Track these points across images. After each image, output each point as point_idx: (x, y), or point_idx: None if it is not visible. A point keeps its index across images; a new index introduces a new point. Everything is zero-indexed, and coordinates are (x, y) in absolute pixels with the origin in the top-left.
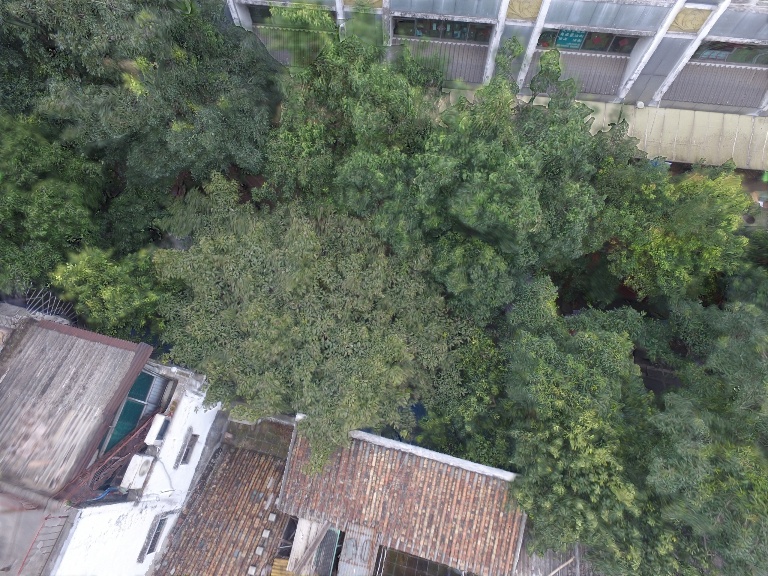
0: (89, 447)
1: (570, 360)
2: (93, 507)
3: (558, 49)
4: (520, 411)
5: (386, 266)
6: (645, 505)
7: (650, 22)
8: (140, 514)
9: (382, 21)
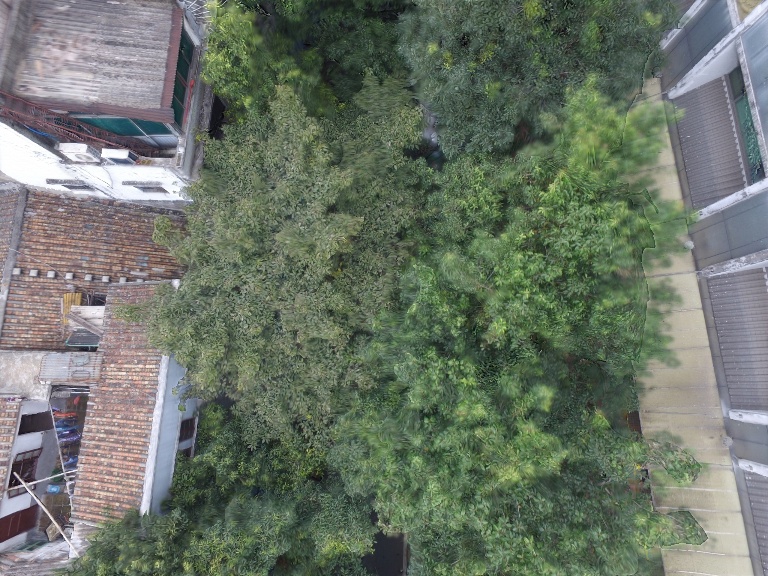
0: (61, 104)
1: (259, 575)
2: (12, 128)
3: None
4: None
5: (348, 336)
6: None
7: None
8: (66, 168)
9: None
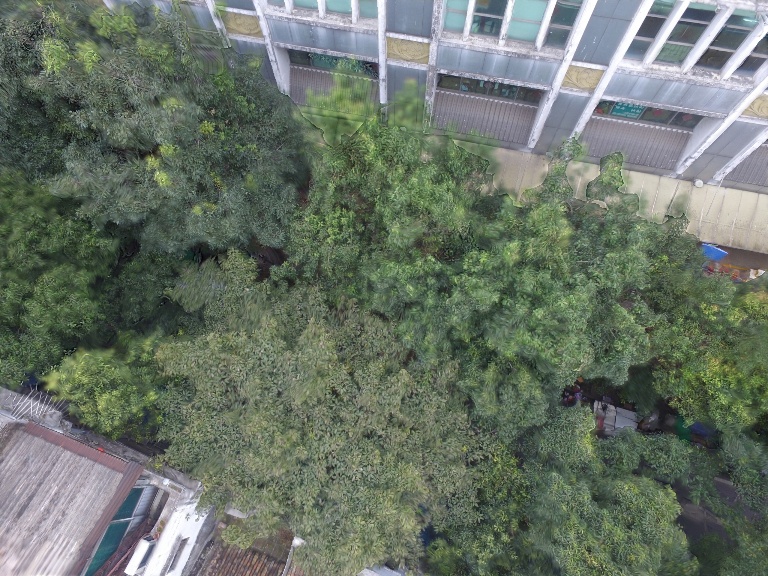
0: None
1: (605, 517)
2: None
3: (614, 117)
4: (541, 553)
5: None
6: None
7: (722, 104)
8: None
9: (426, 77)
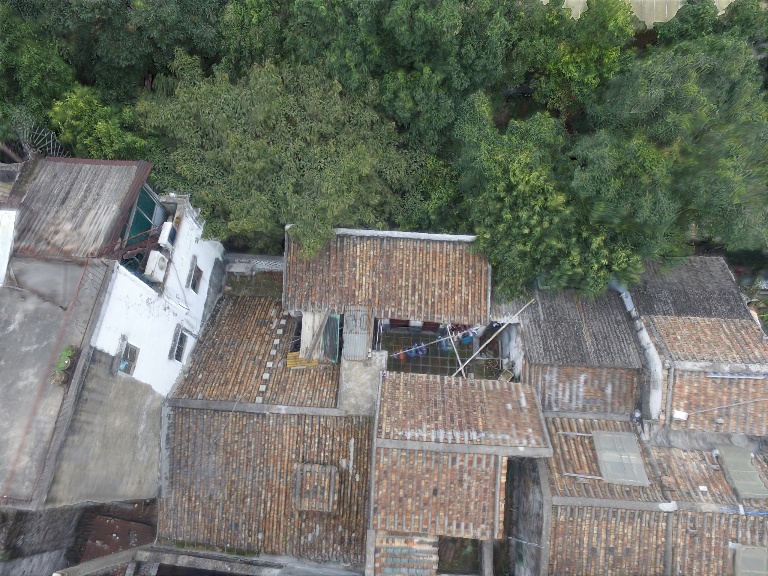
0: (113, 232)
1: None
2: (126, 270)
3: None
4: None
5: None
6: (580, 228)
7: None
8: (164, 311)
9: None
